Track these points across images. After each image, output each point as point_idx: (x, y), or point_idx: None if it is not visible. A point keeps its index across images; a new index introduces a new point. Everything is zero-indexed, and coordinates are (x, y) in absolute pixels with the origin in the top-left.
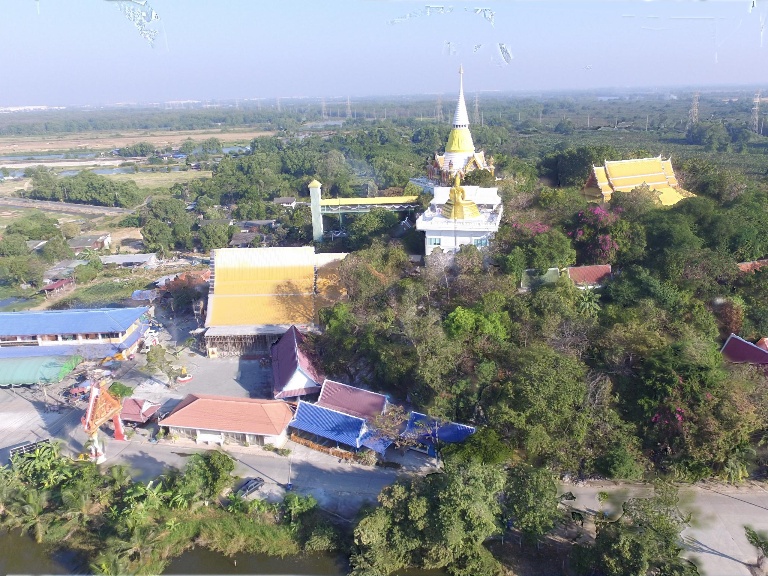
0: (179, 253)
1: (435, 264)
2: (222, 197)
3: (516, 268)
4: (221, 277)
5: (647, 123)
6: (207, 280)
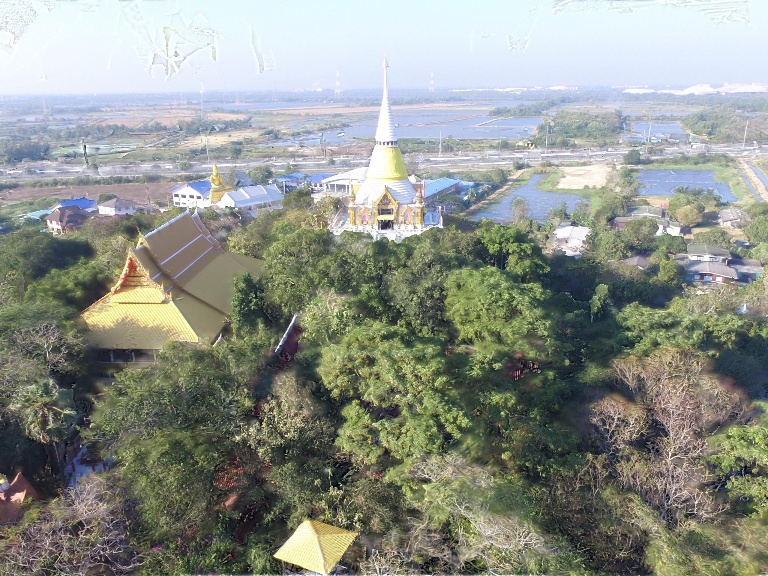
0: None
1: None
2: None
3: None
4: None
5: None
6: None
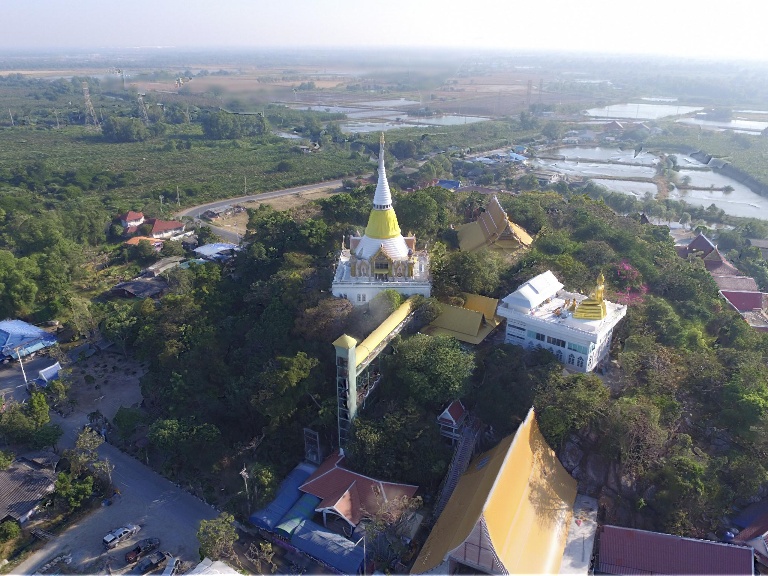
0: None
1: None
2: None
3: None
4: (499, 545)
5: (11, 117)
6: None
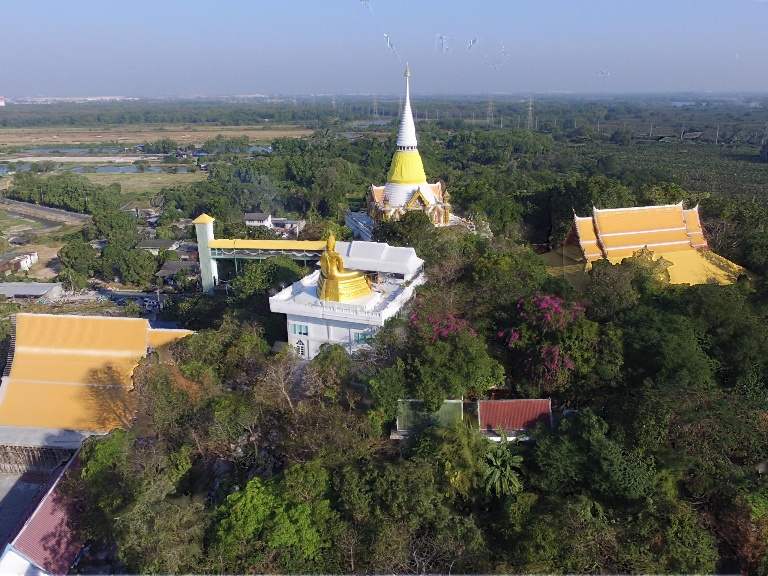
0: (96, 282)
1: (264, 380)
2: (196, 208)
3: (384, 401)
4: (22, 353)
5: (717, 135)
6: None
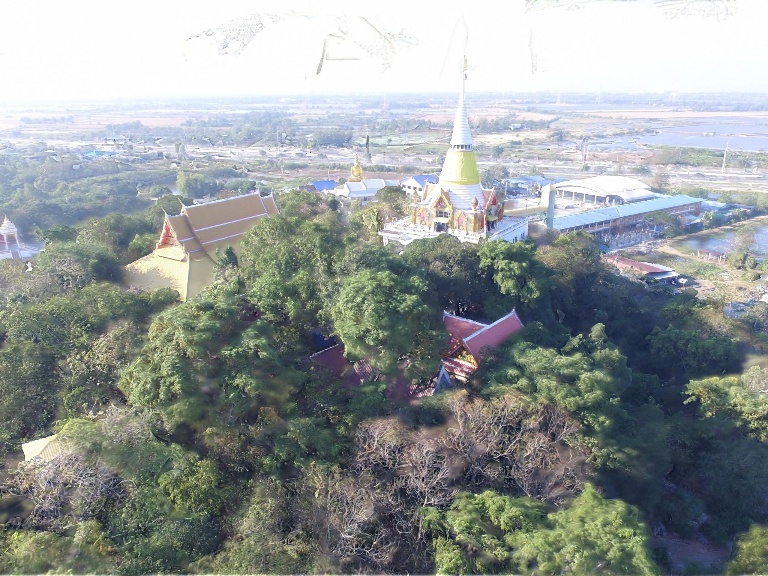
0: None
1: None
2: None
3: None
4: None
5: None
6: (622, 269)
